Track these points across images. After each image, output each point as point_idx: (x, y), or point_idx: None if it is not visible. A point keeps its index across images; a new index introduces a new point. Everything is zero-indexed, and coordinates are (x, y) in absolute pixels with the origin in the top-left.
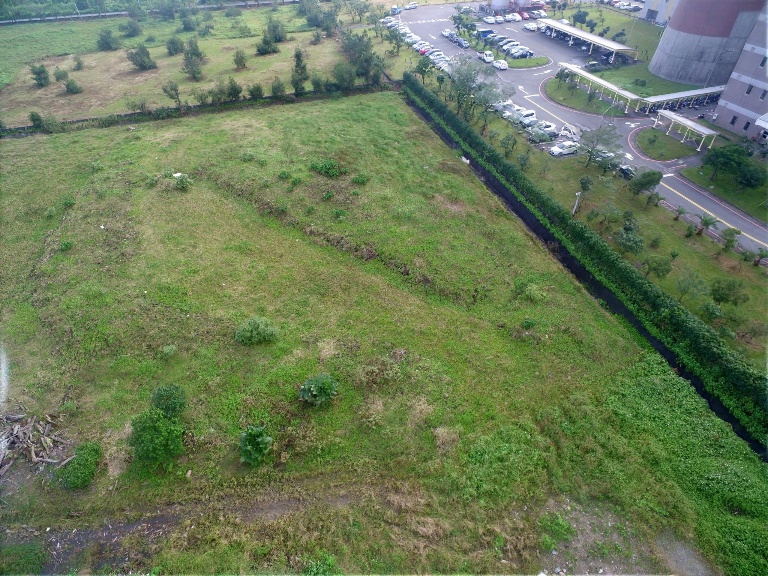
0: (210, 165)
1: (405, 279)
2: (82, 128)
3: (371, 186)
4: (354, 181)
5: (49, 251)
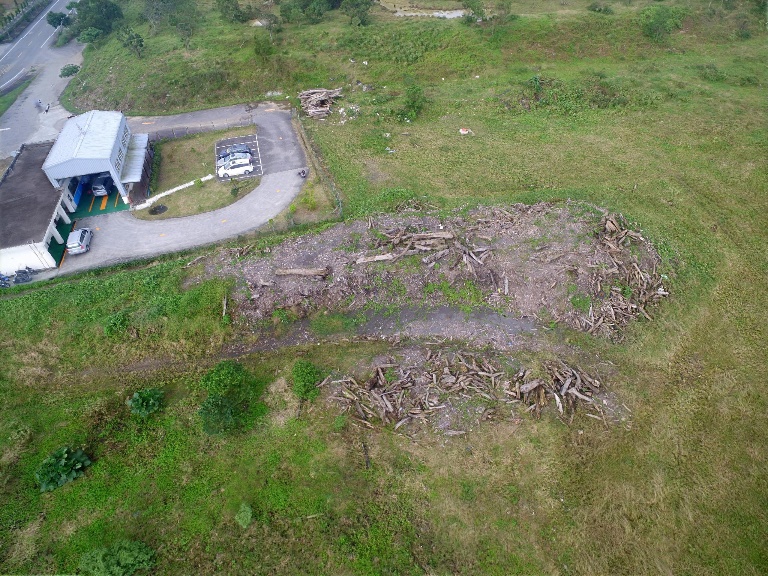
0: None
1: None
2: None
3: None
4: None
5: None
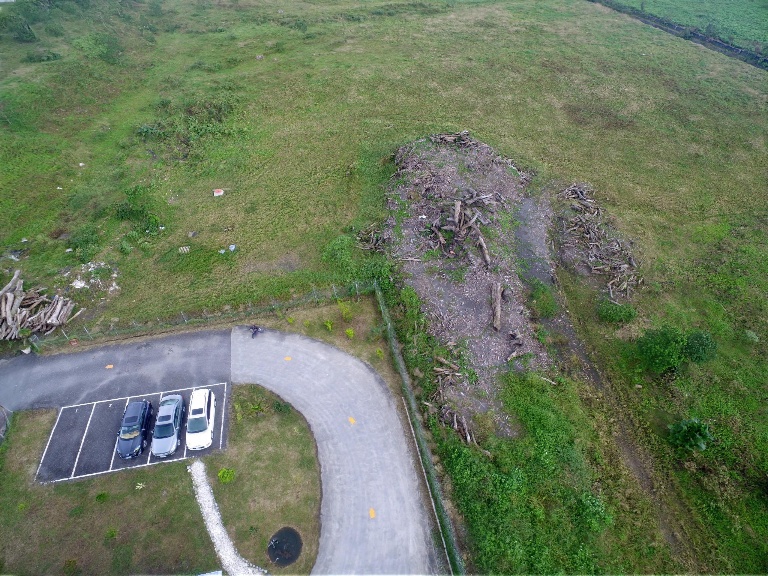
0: None
1: None
2: None
3: None
4: None
5: None
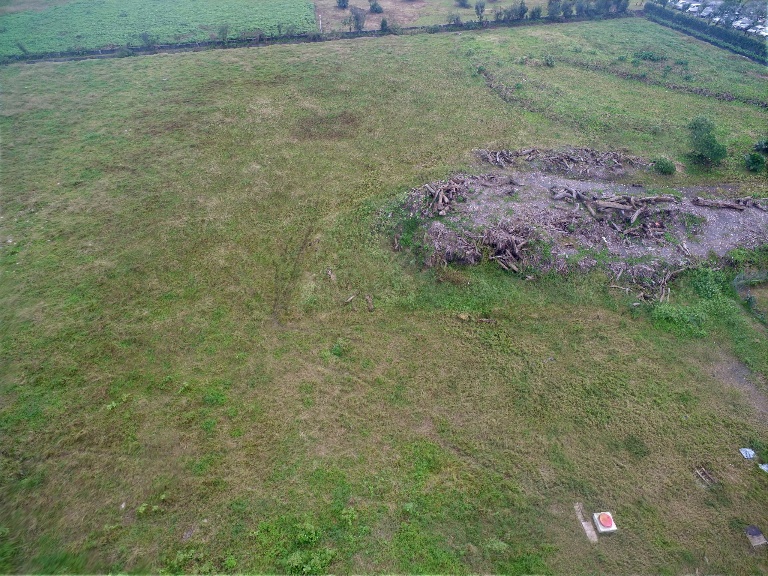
0: (552, 54)
1: (766, 109)
2: (415, 33)
3: (691, 66)
4: (678, 62)
5: (505, 89)
